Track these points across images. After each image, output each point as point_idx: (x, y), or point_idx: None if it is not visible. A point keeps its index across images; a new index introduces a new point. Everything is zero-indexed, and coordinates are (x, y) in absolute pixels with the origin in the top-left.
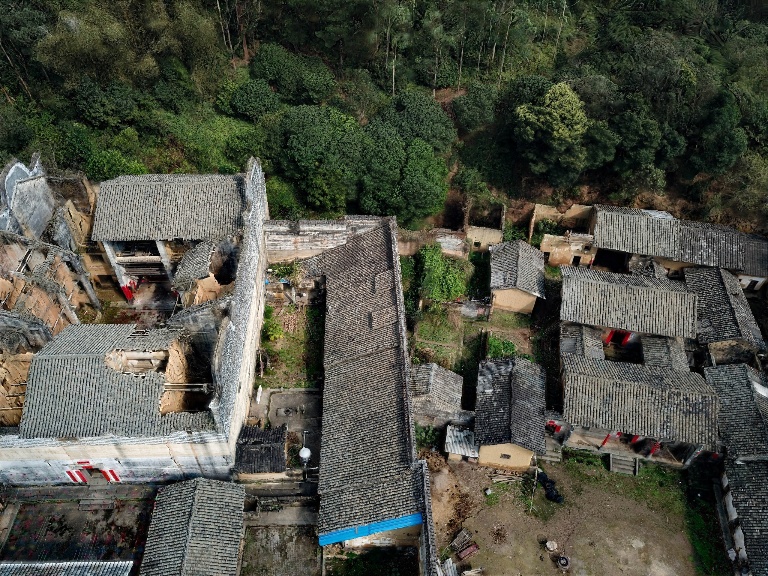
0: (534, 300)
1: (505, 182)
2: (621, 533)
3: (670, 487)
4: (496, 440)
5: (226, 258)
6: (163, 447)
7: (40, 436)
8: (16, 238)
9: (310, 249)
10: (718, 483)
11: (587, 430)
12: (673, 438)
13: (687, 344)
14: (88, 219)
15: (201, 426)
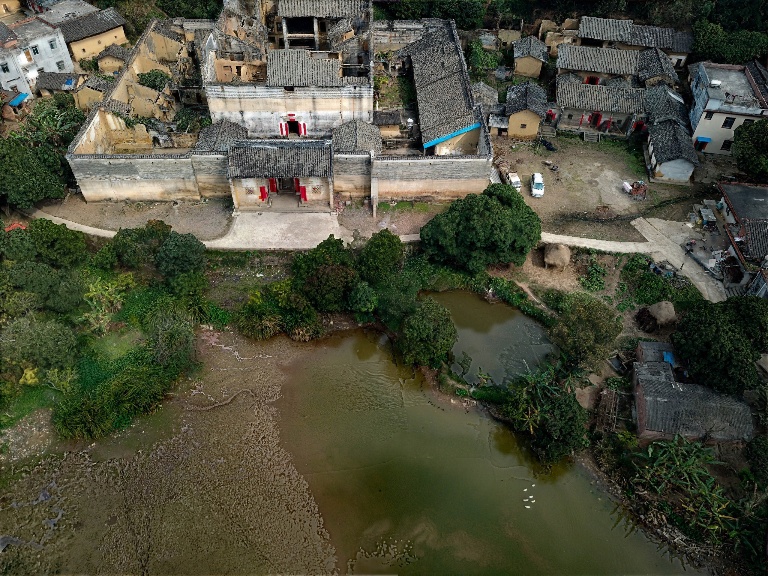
0: (541, 65)
1: (522, 11)
2: (588, 161)
3: (618, 147)
4: (518, 109)
5: (356, 30)
6: (338, 101)
7: (278, 85)
8: (236, 13)
9: (399, 43)
10: (646, 144)
11: (571, 119)
12: (619, 111)
13: (633, 84)
14: (264, 18)
15: (362, 82)
